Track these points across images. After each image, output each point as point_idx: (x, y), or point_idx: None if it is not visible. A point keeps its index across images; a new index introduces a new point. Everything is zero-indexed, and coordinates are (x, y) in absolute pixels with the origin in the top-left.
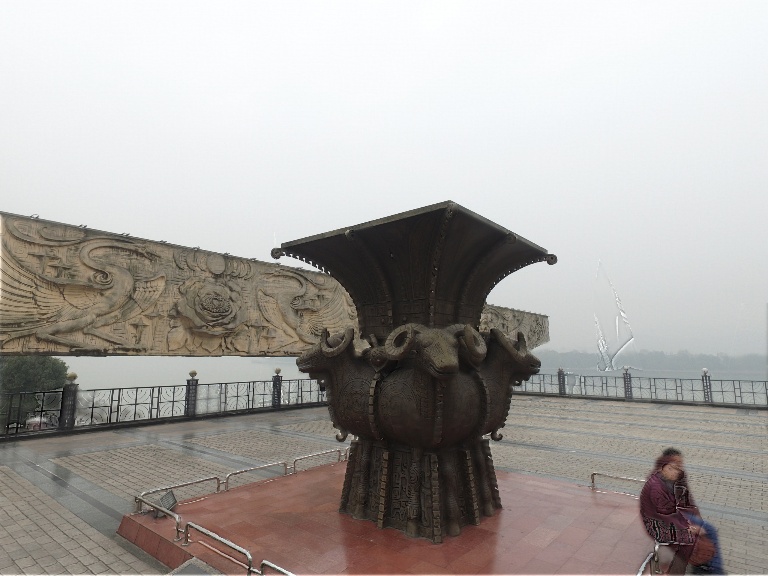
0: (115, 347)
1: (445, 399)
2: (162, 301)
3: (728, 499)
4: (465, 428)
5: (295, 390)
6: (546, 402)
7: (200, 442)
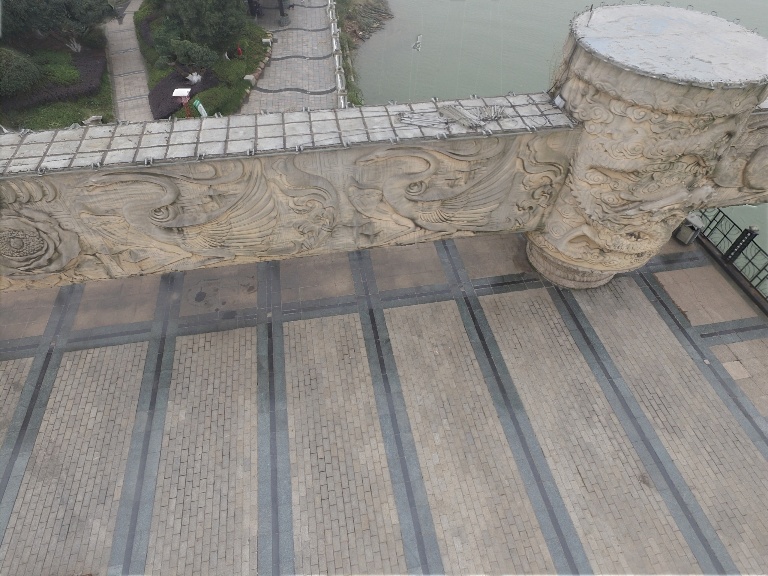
0: None
1: None
2: None
3: None
4: None
5: None
6: (705, 377)
7: (63, 375)
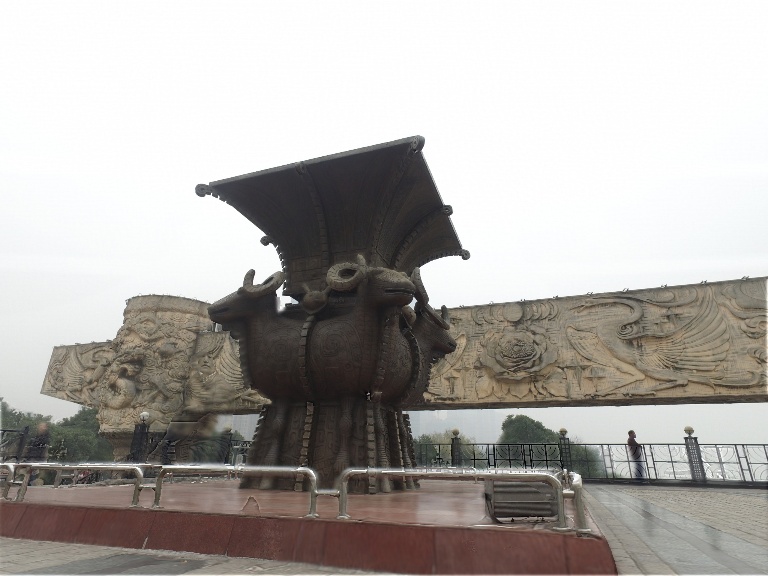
0: (435, 397)
1: (249, 345)
2: (467, 355)
3: None
4: (282, 375)
5: (733, 460)
6: None
7: None
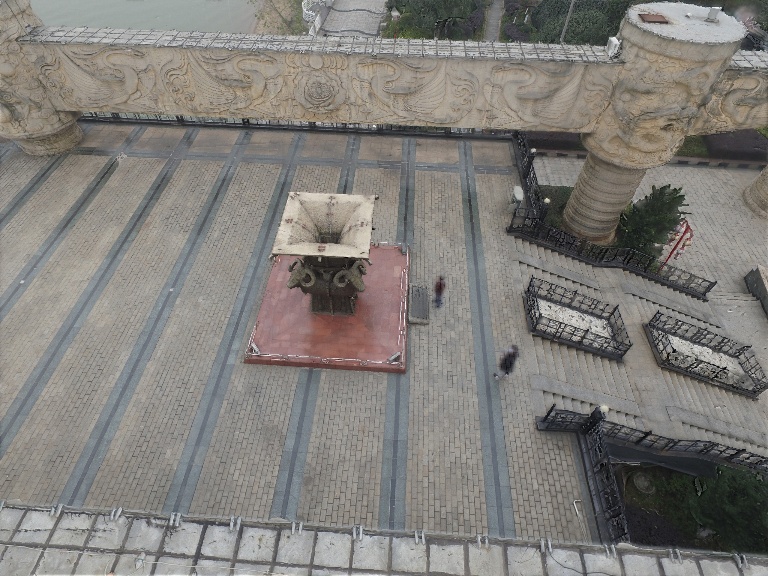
0: None
1: None
2: None
3: (248, 237)
4: None
5: None
6: None
7: None
